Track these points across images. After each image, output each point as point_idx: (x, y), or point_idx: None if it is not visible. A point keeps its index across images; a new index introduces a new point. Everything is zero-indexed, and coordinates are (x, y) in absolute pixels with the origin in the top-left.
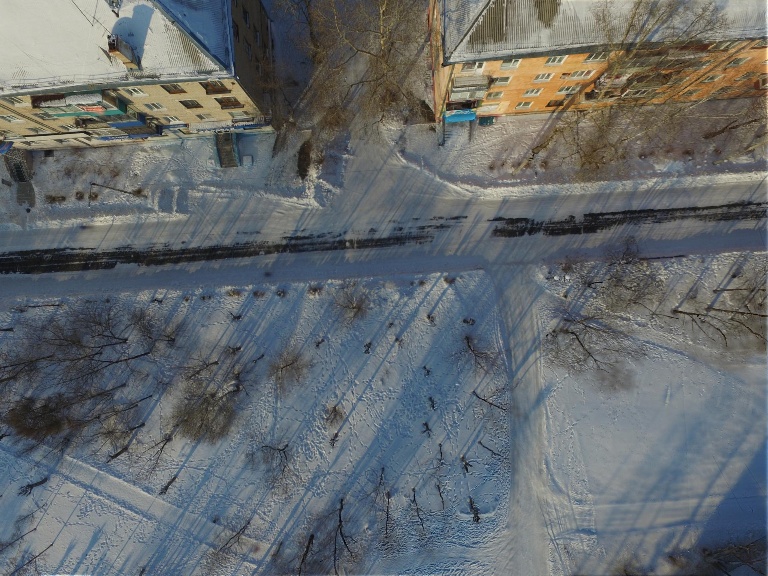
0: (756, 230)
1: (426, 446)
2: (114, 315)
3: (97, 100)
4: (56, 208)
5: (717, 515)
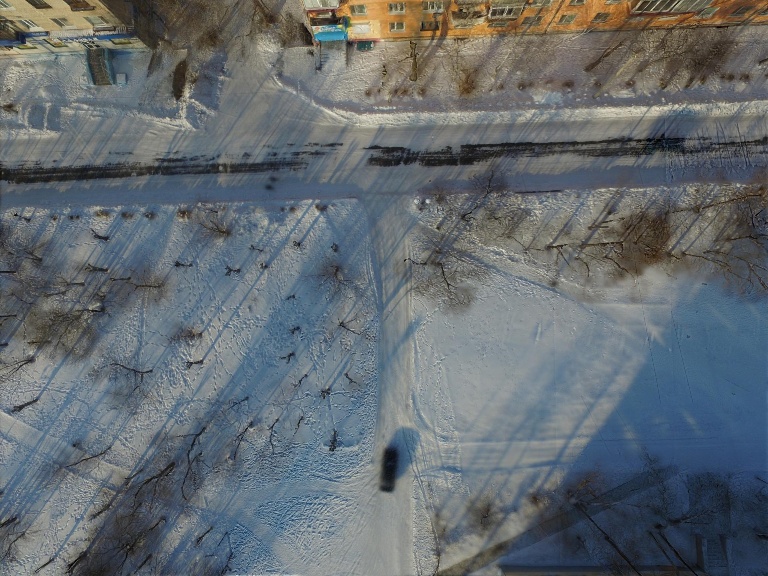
0: (635, 167)
1: (292, 376)
2: None
3: None
4: None
5: (584, 457)
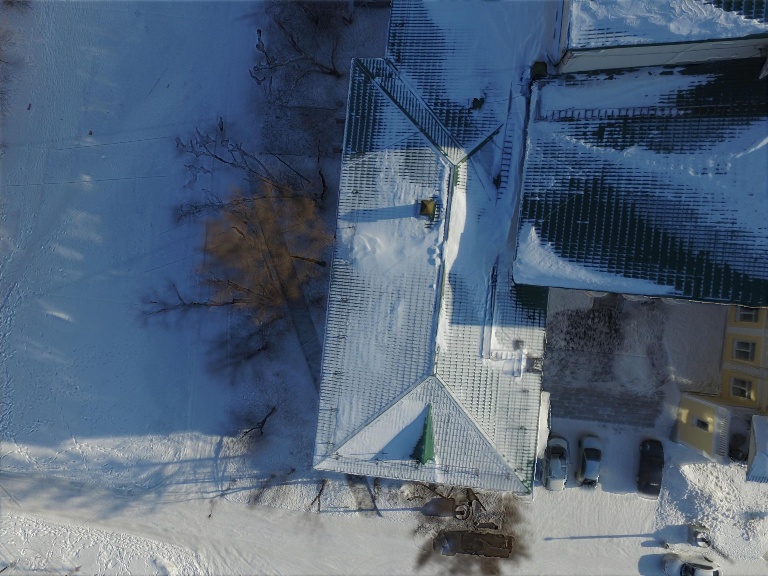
0: None
1: None
2: None
3: None
4: None
5: (223, 278)
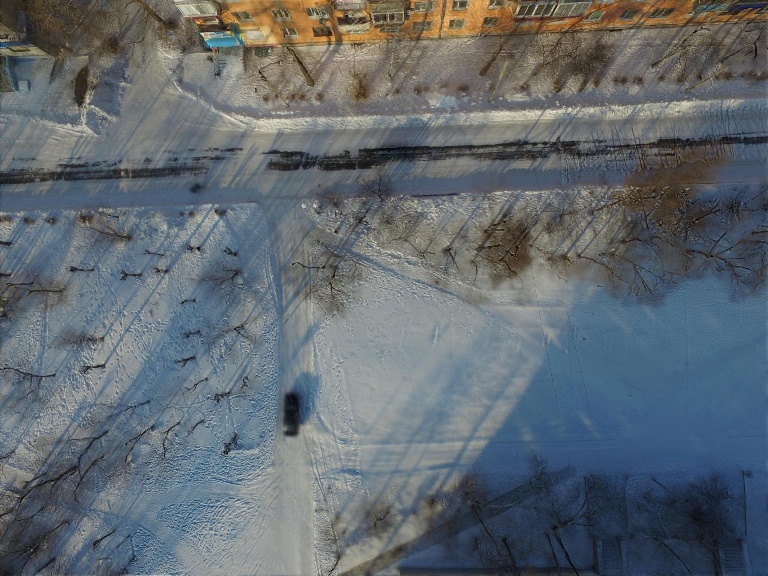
0: (531, 170)
1: (193, 380)
2: None
3: None
4: None
5: (483, 459)
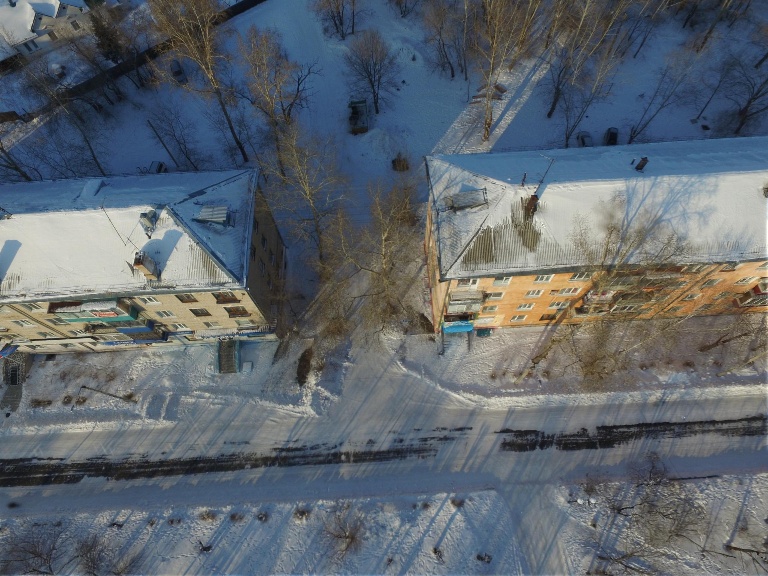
0: None
1: None
2: (61, 543)
3: (111, 307)
4: (38, 413)
5: None
